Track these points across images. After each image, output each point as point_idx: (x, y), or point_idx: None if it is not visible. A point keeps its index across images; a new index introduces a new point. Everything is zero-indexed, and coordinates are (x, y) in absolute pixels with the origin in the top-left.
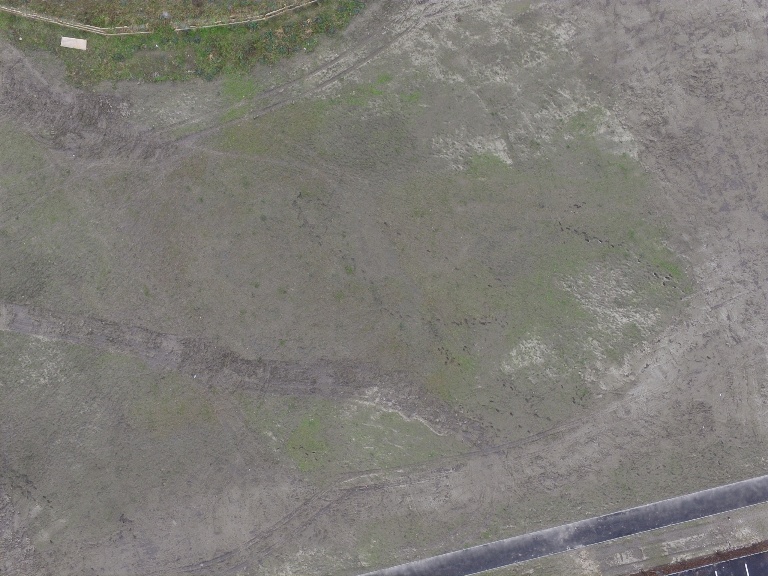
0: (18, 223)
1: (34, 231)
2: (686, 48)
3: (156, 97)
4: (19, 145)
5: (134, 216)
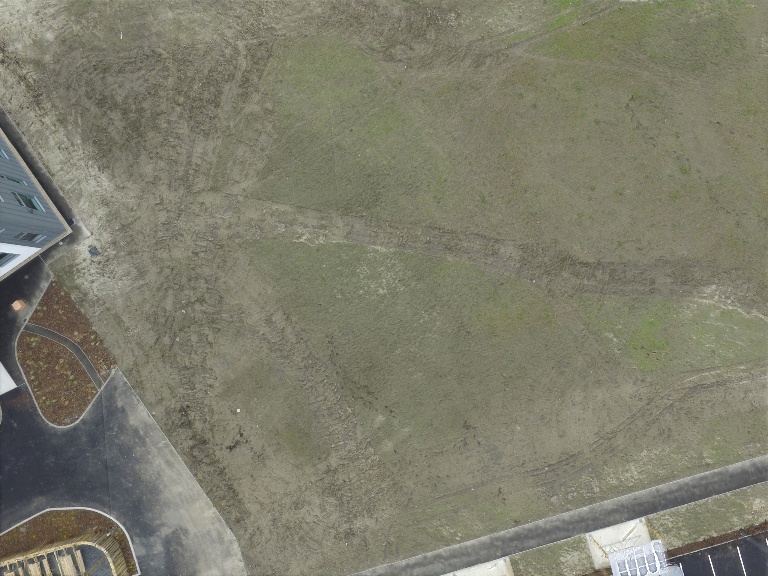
0: (352, 135)
1: (368, 143)
2: None
3: (483, 7)
4: (350, 58)
5: (468, 124)
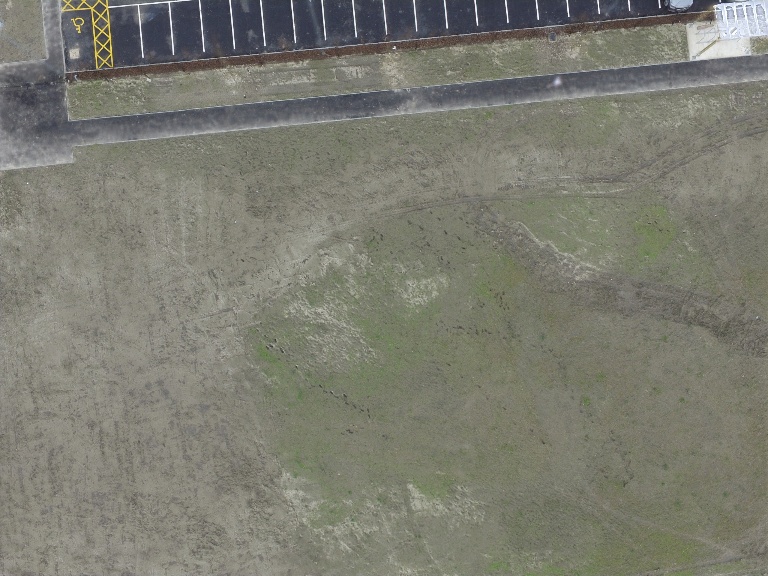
0: None
1: None
2: (217, 574)
3: None
4: None
5: None
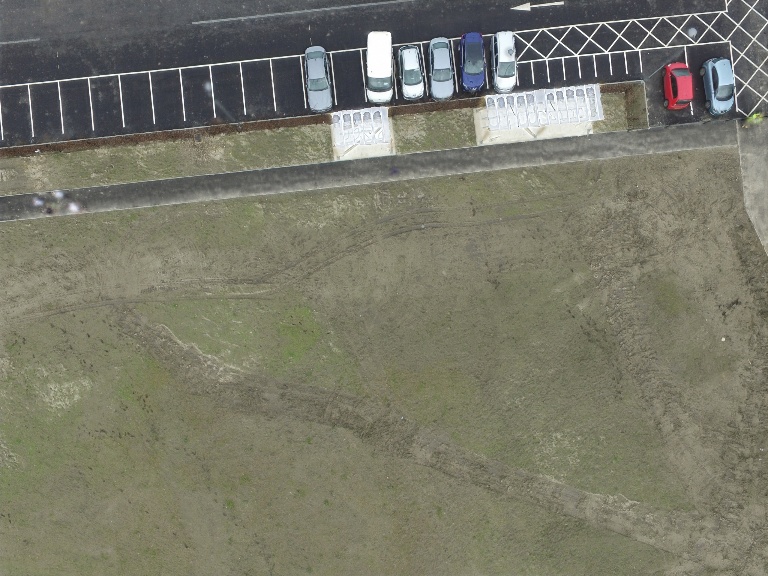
0: None
1: None
2: None
3: None
4: None
5: None
